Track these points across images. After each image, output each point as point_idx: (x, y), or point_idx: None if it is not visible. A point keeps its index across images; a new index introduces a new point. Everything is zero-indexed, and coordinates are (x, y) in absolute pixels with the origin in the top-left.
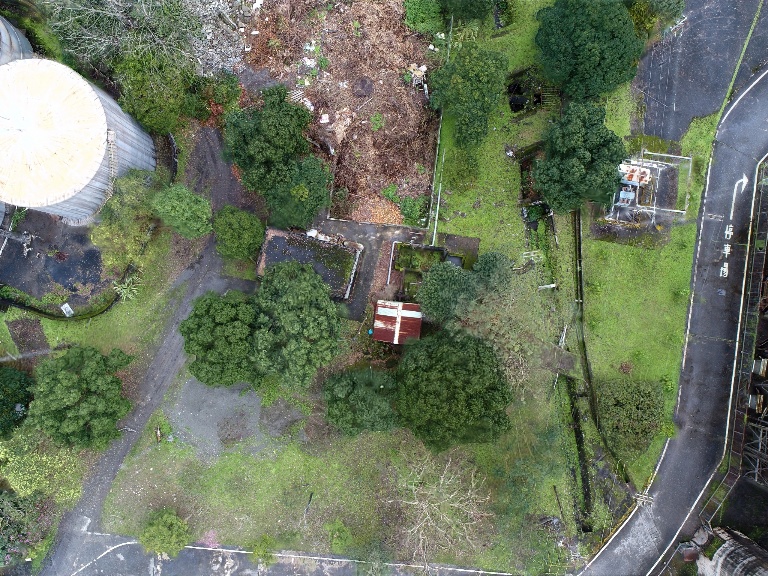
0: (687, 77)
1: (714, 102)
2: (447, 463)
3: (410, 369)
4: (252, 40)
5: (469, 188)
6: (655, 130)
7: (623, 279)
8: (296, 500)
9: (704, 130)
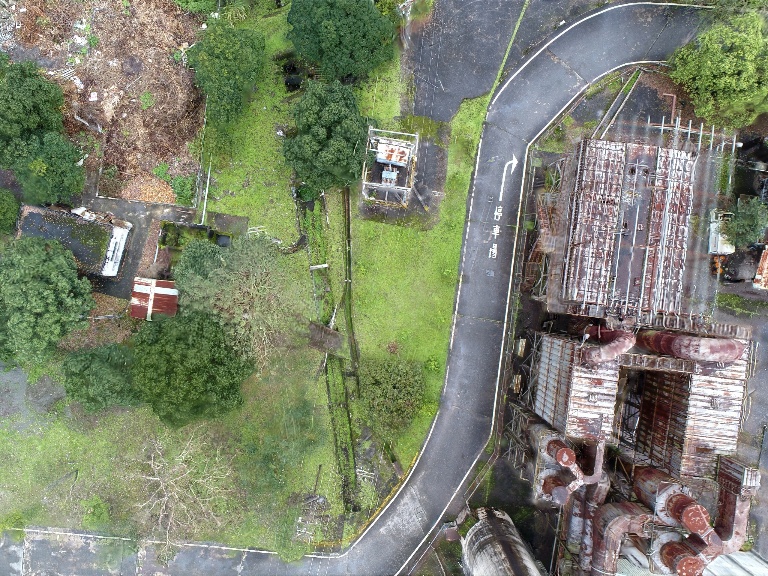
0: (457, 58)
1: (485, 83)
2: (189, 439)
3: (136, 343)
4: (20, 17)
5: (238, 167)
6: (425, 111)
7: (392, 259)
8: (62, 477)
9: (474, 111)
